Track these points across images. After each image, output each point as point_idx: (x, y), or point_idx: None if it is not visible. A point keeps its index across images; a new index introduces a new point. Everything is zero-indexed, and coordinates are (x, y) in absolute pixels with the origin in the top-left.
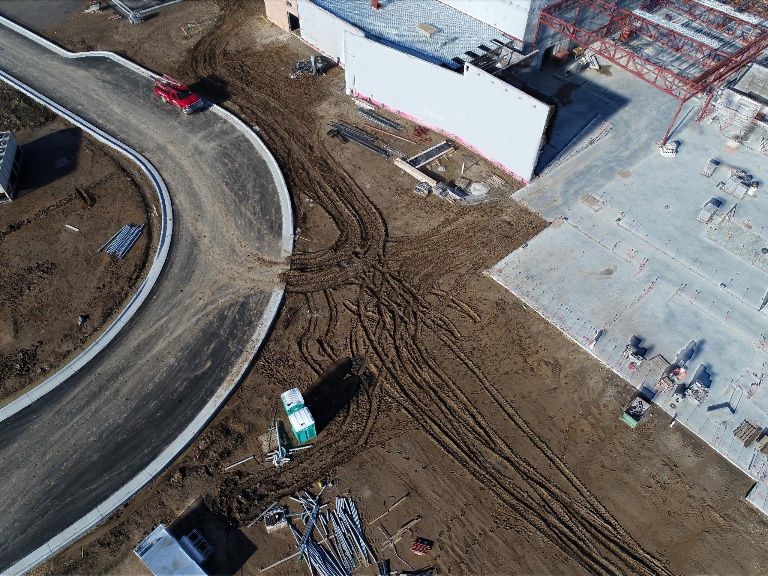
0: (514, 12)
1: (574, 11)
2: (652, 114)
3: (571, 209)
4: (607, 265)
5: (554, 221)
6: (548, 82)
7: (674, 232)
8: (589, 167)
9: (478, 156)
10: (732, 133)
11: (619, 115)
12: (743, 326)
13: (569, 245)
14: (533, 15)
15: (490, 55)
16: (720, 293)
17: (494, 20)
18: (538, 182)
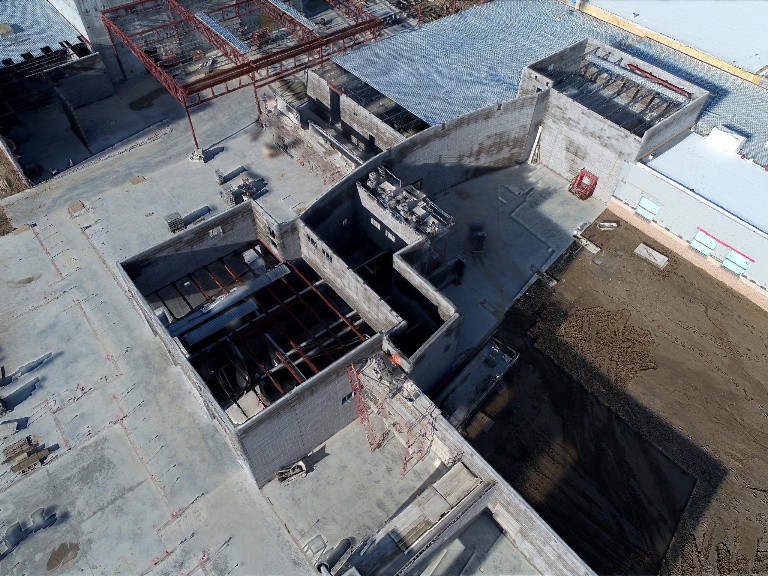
0: (75, 14)
1: (165, 13)
2: (221, 119)
3: (49, 215)
4: (33, 273)
5: (19, 227)
6: (145, 85)
7: (133, 240)
8: (107, 172)
9: (5, 159)
10: (279, 140)
11: (187, 120)
12: (116, 338)
13: (13, 252)
14: (90, 17)
15: (52, 57)
16: (123, 304)
17: (73, 21)
18: (40, 187)
